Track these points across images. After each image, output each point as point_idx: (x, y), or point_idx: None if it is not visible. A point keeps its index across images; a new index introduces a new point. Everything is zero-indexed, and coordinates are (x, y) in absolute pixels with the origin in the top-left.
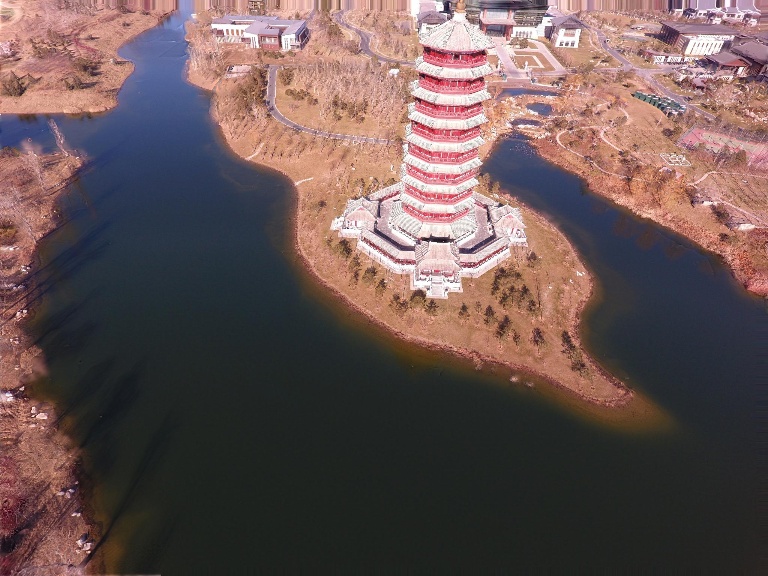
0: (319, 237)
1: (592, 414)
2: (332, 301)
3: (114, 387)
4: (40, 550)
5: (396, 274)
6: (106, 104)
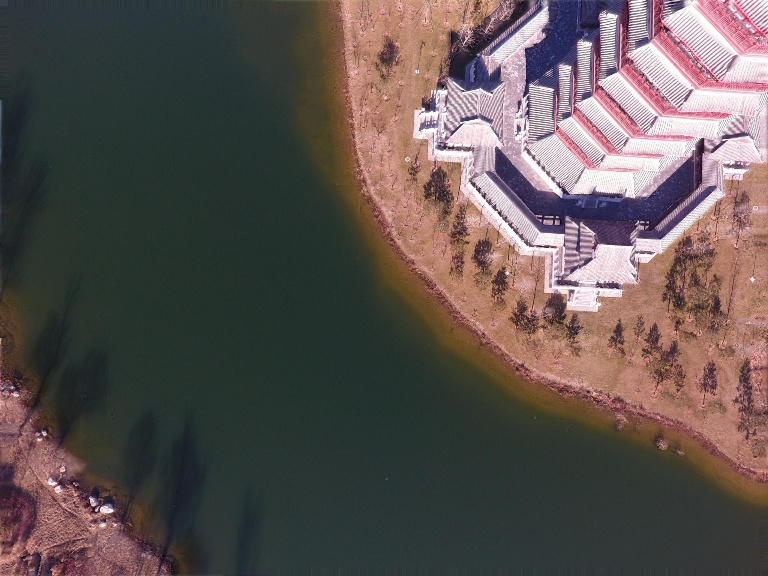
0: (395, 157)
1: (741, 490)
2: (425, 301)
3: (172, 462)
4: None
5: (524, 257)
6: None
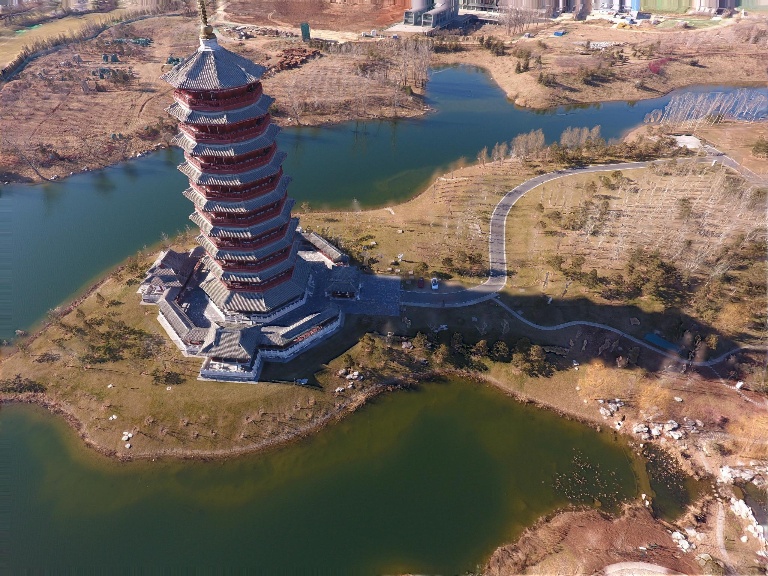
0: None
1: None
2: None
3: (149, 169)
4: (58, 167)
5: None
6: (534, 103)
